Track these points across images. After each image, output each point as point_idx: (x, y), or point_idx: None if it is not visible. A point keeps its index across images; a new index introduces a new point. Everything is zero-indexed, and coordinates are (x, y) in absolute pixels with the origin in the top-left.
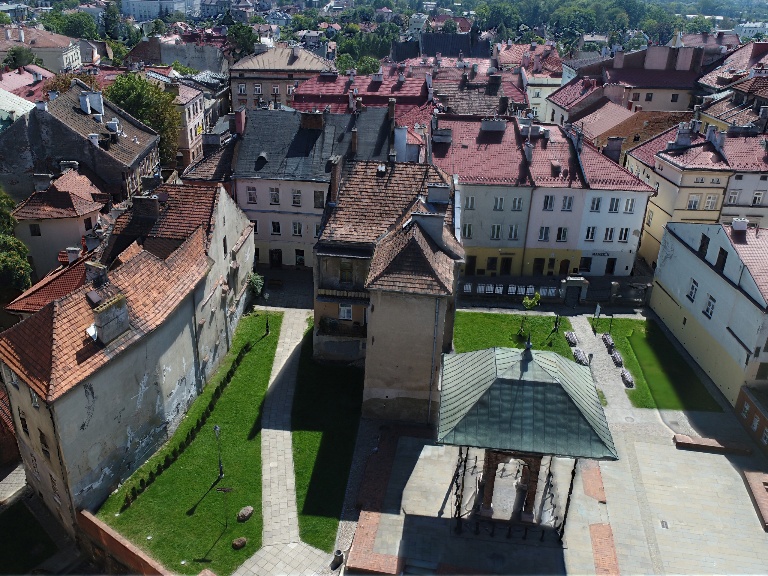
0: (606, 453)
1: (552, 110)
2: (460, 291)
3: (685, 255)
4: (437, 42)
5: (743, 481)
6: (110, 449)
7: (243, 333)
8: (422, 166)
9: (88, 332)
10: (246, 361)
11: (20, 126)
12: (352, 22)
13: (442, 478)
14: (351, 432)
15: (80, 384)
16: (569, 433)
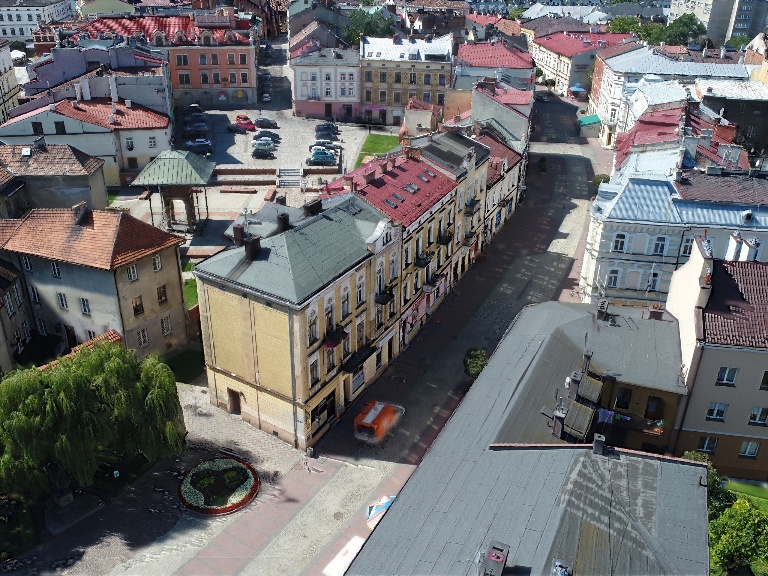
0: None
1: None
2: None
3: (23, 142)
4: None
5: None
6: None
7: None
8: None
9: None
10: None
11: None
12: None
13: None
14: None
15: None
16: None
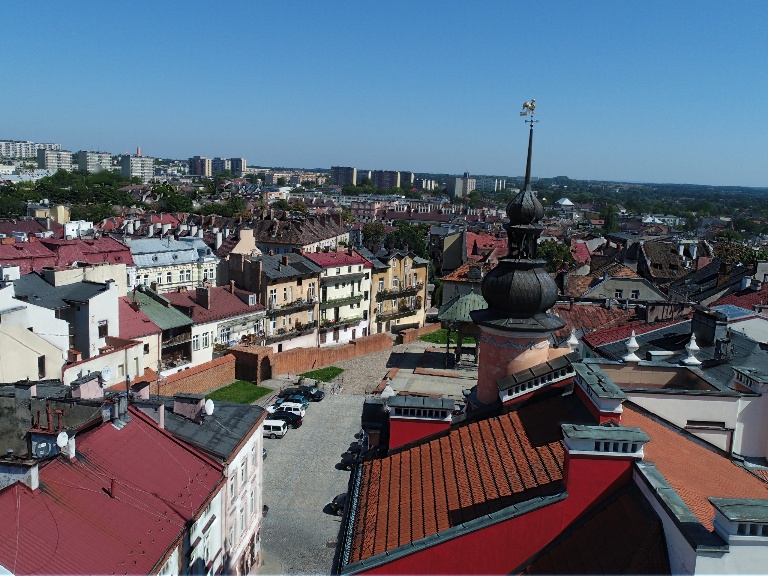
0: None
1: None
2: None
3: None
4: None
5: None
6: None
7: None
8: None
9: None
10: None
11: None
12: None
13: None
14: None
15: (453, 282)
16: None
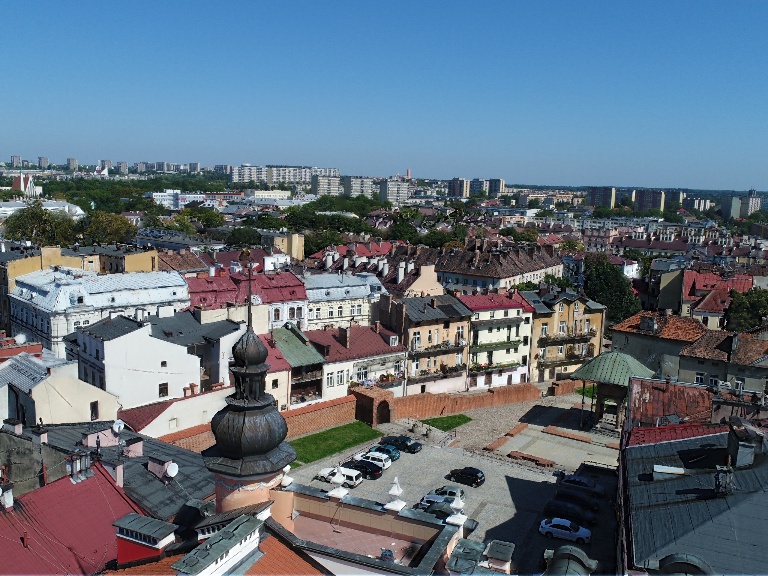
0: None
1: None
2: None
3: None
4: None
5: None
6: None
7: None
8: None
9: None
10: None
11: None
12: None
13: None
14: None
15: (622, 332)
16: None
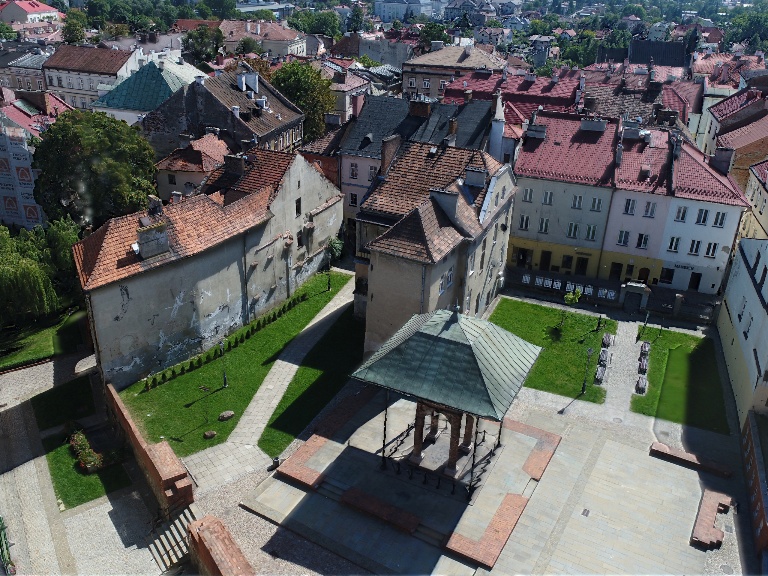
0: (491, 413)
1: (711, 121)
2: (519, 281)
3: (744, 272)
4: (648, 49)
5: (700, 498)
6: (142, 344)
7: (309, 286)
8: (470, 151)
9: (133, 247)
10: (298, 308)
11: (180, 95)
12: (591, 29)
13: (398, 426)
14: (346, 376)
15: (114, 283)
16: (464, 390)
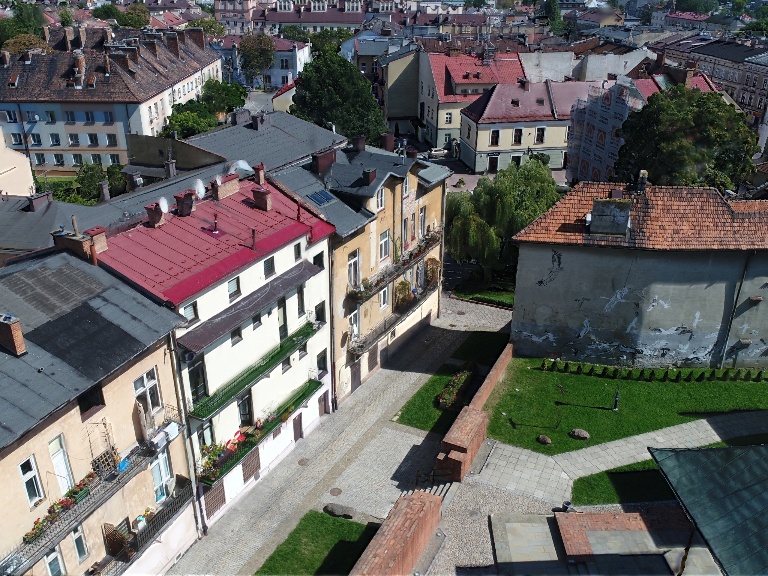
0: None
1: None
2: None
3: None
4: None
5: None
6: (561, 322)
7: None
8: None
9: (587, 216)
10: None
11: None
12: None
13: None
14: None
15: (546, 244)
16: None
